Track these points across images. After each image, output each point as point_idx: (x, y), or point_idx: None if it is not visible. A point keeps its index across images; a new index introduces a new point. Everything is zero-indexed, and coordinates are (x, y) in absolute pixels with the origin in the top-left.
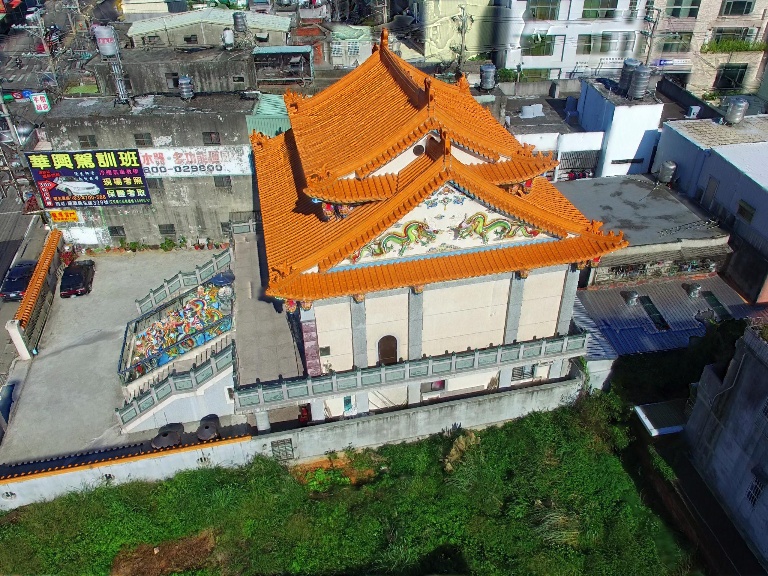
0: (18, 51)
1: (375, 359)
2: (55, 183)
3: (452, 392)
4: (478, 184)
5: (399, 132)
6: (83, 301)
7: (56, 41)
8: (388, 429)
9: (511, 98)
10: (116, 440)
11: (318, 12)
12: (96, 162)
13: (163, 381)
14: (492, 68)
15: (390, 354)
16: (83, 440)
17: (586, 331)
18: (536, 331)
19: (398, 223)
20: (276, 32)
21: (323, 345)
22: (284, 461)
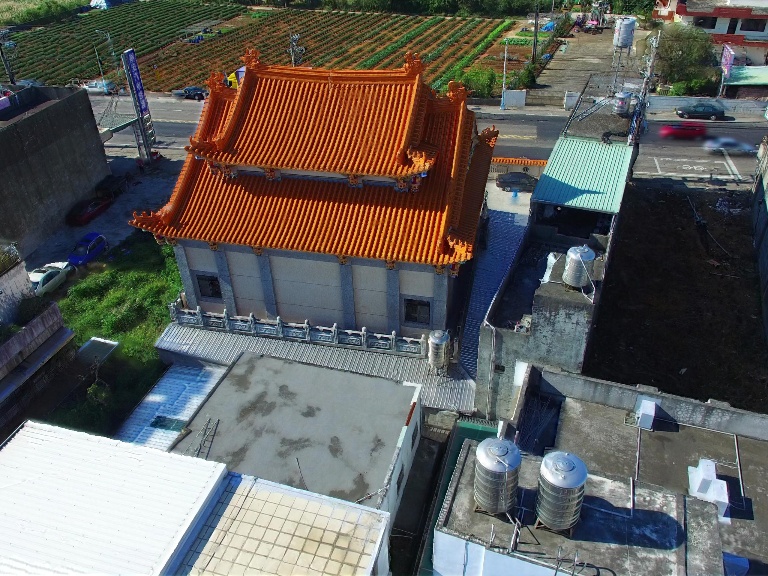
0: None
1: None
2: None
3: None
4: None
5: None
6: (495, 189)
7: None
8: None
9: None
10: None
11: None
12: None
13: None
14: None
15: None
16: None
17: None
18: None
19: None
20: None
21: None
22: None
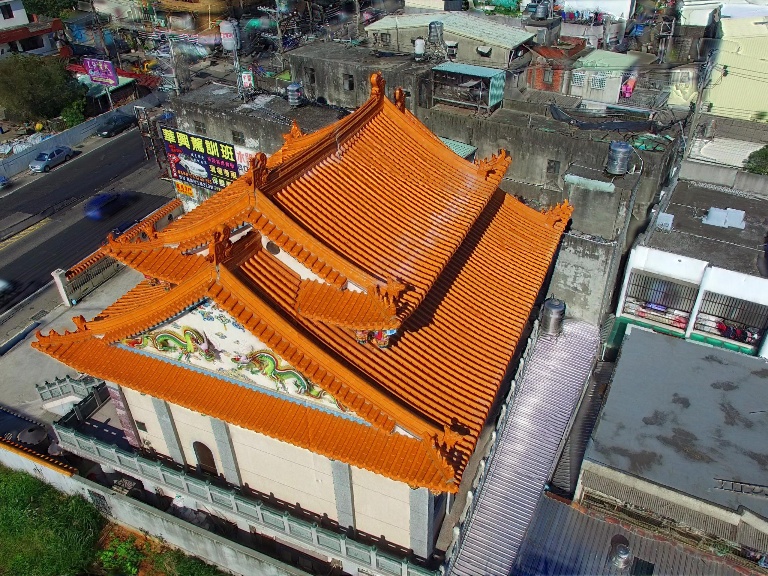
0: (261, 30)
1: (194, 460)
2: (179, 158)
3: (289, 542)
4: (260, 313)
5: (222, 212)
6: None
7: (294, 26)
8: (196, 542)
9: (724, 190)
10: (35, 411)
11: (597, 31)
12: (205, 148)
13: (63, 379)
14: (625, 147)
15: (212, 463)
16: (20, 398)
17: (436, 571)
18: (383, 530)
19: (176, 323)
20: (500, 48)
21: (138, 419)
22: (105, 513)
